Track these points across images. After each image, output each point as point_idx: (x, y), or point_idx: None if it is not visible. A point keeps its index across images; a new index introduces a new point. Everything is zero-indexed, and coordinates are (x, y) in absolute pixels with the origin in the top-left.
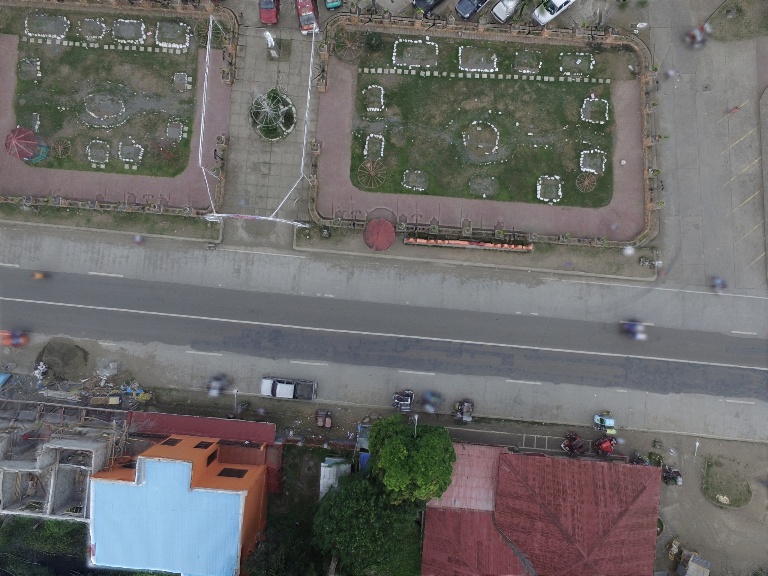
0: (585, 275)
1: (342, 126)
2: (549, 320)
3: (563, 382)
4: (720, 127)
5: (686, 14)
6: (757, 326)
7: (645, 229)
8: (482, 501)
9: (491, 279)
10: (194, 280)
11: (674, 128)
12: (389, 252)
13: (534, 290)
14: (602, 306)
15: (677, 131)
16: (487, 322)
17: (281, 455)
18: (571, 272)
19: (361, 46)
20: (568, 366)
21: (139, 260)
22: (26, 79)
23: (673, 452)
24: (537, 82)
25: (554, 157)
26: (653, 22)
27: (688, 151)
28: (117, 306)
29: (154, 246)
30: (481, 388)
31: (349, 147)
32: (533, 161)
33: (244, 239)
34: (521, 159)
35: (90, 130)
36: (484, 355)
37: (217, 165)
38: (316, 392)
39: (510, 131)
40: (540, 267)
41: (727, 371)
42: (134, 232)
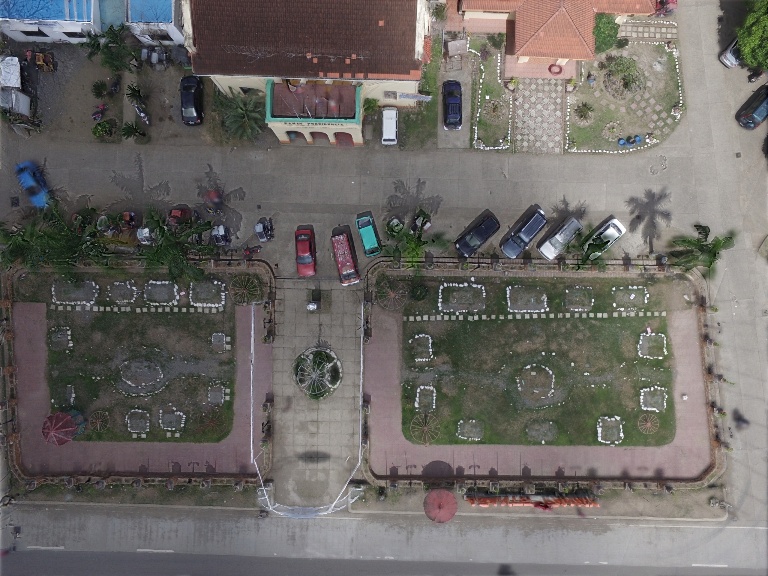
0: (653, 519)
1: (390, 378)
2: (619, 568)
3: None
4: None
5: (740, 236)
6: None
7: (713, 467)
8: None
9: (556, 529)
10: (248, 551)
11: (735, 357)
12: None
13: (601, 537)
14: (673, 550)
15: (738, 360)
16: (555, 574)
17: None
18: (639, 518)
19: (405, 295)
20: None
21: (189, 533)
22: (57, 350)
23: None
24: (590, 319)
25: (613, 396)
26: None
27: (751, 380)
28: None
29: (203, 517)
30: None
31: (399, 399)
32: (591, 402)
33: (296, 503)
34: (579, 400)
35: (128, 399)
36: None
37: None
38: None
39: (565, 372)
40: (606, 514)
41: None
42: (182, 505)
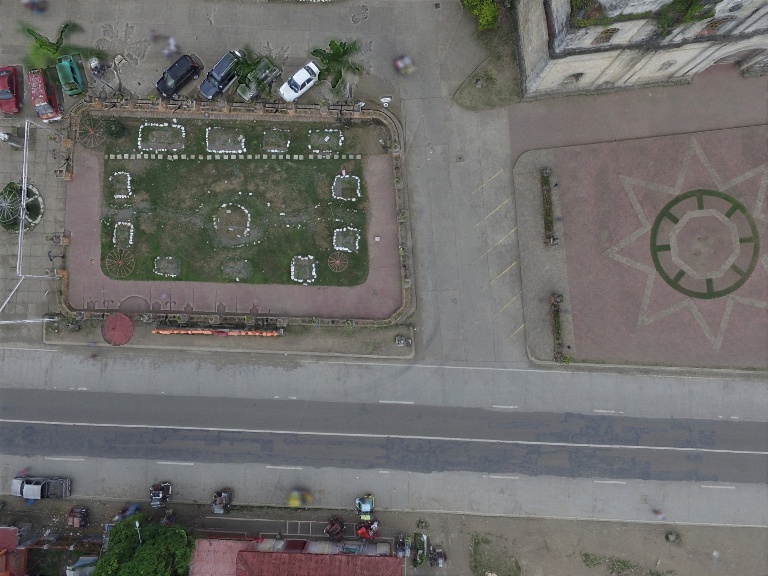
0: (342, 356)
1: (91, 214)
2: (307, 403)
3: (324, 466)
4: (475, 198)
5: (437, 85)
6: (518, 399)
7: (401, 306)
8: None
9: (247, 364)
10: None
11: (428, 201)
12: (141, 342)
13: (291, 373)
14: (361, 386)
15: (432, 204)
16: (245, 408)
17: (24, 560)
18: (327, 354)
19: (104, 133)
20: (329, 449)
21: None
22: None
23: (423, 537)
24: (287, 161)
25: (307, 236)
26: (404, 94)
27: (443, 224)
28: None
29: None
30: (241, 476)
31: (98, 236)
32: (286, 241)
33: None
34: (274, 240)
35: None
36: (243, 442)
37: None
38: (71, 489)
39: (262, 212)
40: (295, 350)
41: (490, 447)
42: None
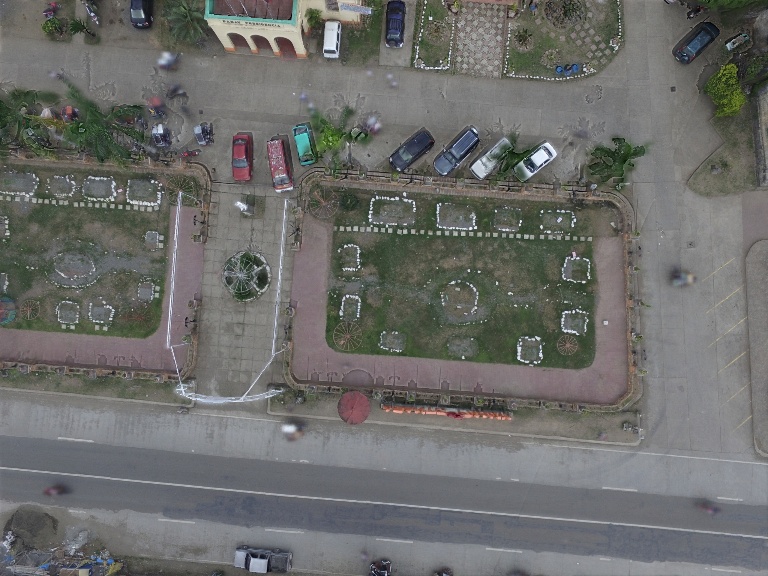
0: (567, 440)
1: (317, 285)
2: (530, 486)
3: (545, 550)
4: (705, 285)
5: (670, 169)
6: (744, 492)
7: (628, 392)
8: None
9: (470, 443)
10: (166, 445)
11: (658, 286)
12: None
13: (515, 455)
14: (584, 471)
15: (661, 290)
16: (466, 488)
17: None
18: (552, 437)
19: (336, 205)
20: (550, 534)
21: (110, 425)
22: None
23: None
24: (517, 240)
25: (535, 317)
26: (636, 177)
27: (672, 310)
28: (87, 473)
29: (125, 410)
30: (460, 556)
31: (325, 307)
32: (513, 321)
33: None
34: (501, 319)
35: (60, 290)
36: (463, 522)
37: (189, 326)
38: (291, 562)
39: (490, 290)
40: (521, 432)
41: (713, 539)
42: (104, 396)
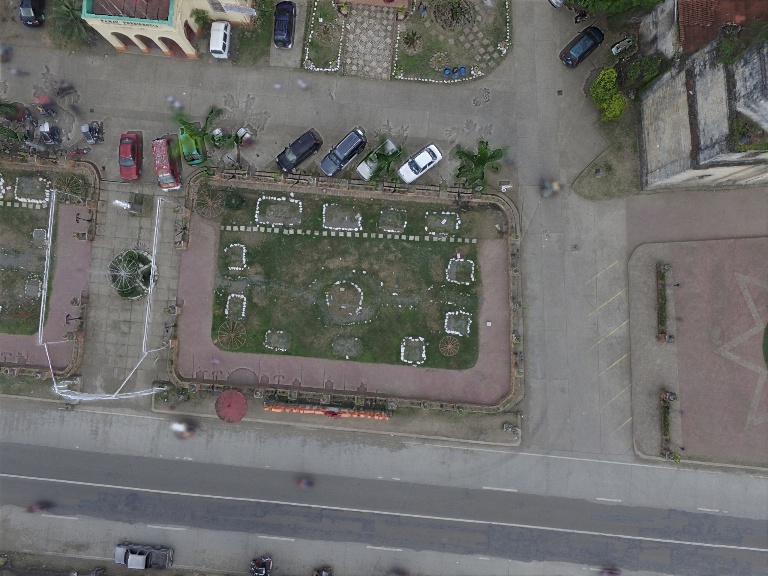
0: (448, 440)
1: (204, 284)
2: (411, 485)
3: (425, 549)
4: (588, 288)
5: (555, 172)
6: (622, 493)
7: (509, 393)
8: None
9: (353, 443)
10: (51, 442)
11: (541, 289)
12: (249, 415)
13: (396, 454)
14: (465, 471)
15: (544, 292)
16: (348, 487)
17: None
18: (434, 437)
19: (223, 204)
20: (430, 532)
21: None
22: None
23: None
24: (402, 241)
25: (419, 318)
26: (522, 180)
27: (555, 312)
28: None
29: (11, 406)
30: (341, 554)
31: (211, 306)
32: (398, 322)
33: None
34: (385, 319)
35: None
36: (345, 521)
37: (76, 323)
38: (172, 559)
39: (374, 291)
40: (402, 432)
41: (591, 539)
42: None
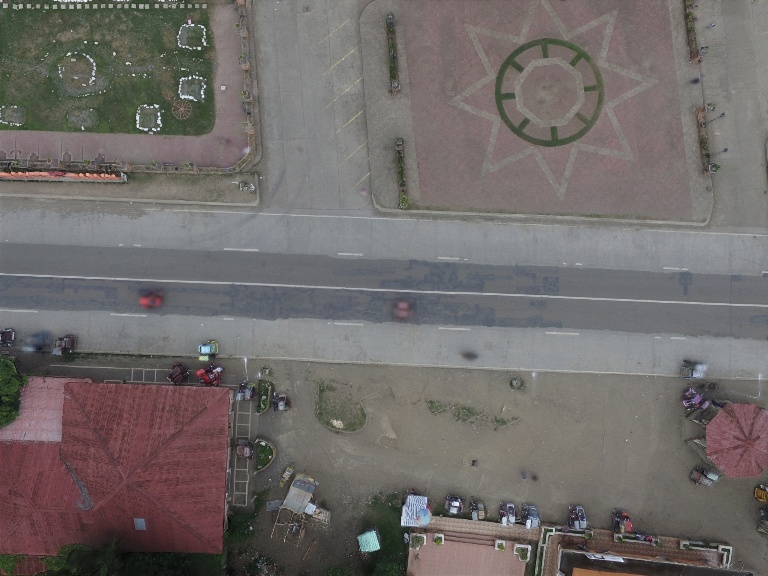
0: (186, 203)
1: None
2: (152, 251)
3: (169, 313)
4: (321, 48)
5: None
6: (363, 247)
7: (245, 154)
8: (53, 433)
9: (92, 212)
10: None
11: (275, 51)
12: None
13: (136, 221)
14: (206, 234)
15: (278, 54)
16: (89, 256)
17: None
18: (171, 201)
19: None
20: (173, 297)
21: None
22: None
23: (258, 375)
24: (133, 10)
25: (153, 86)
26: None
27: (290, 74)
28: None
29: None
30: (85, 323)
31: None
32: (132, 91)
33: None
34: (120, 89)
35: None
36: (87, 290)
37: None
38: None
39: (108, 61)
40: (140, 197)
41: (334, 294)
42: None
